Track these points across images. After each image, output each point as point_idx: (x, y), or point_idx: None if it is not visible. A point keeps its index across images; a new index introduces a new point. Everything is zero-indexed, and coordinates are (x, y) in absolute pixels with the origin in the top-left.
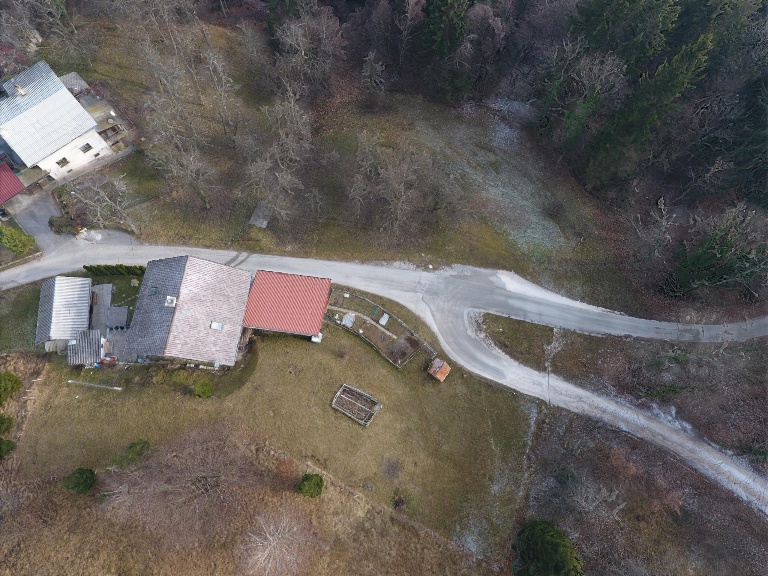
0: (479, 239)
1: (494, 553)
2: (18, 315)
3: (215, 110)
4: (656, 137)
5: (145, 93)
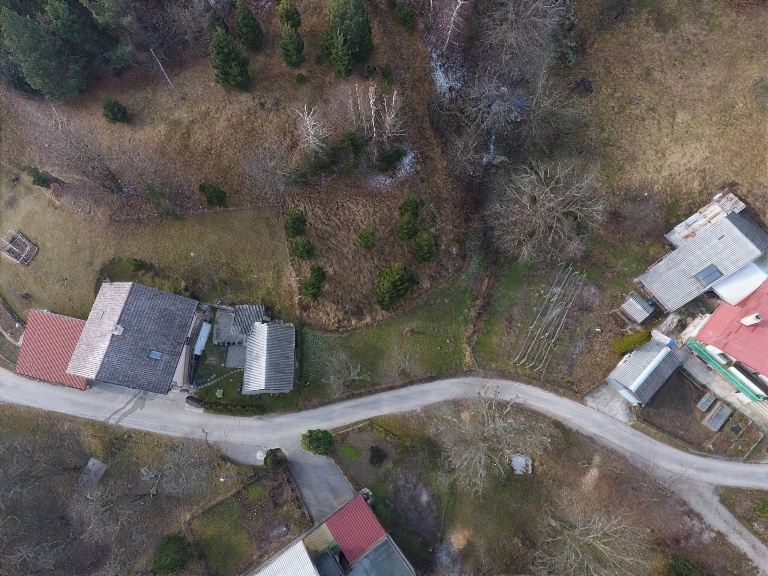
0: None
1: None
2: None
3: None
4: None
5: None
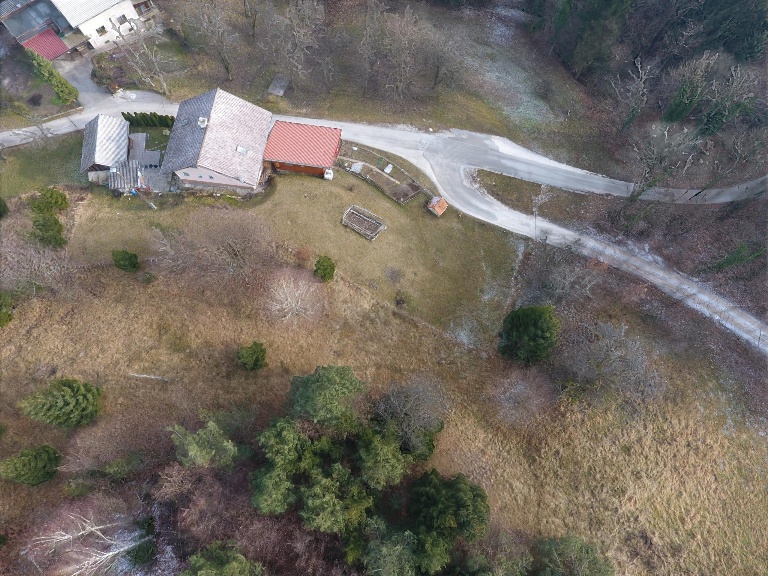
0: (475, 111)
1: (483, 345)
2: (63, 157)
3: (236, 3)
4: (635, 10)
5: None
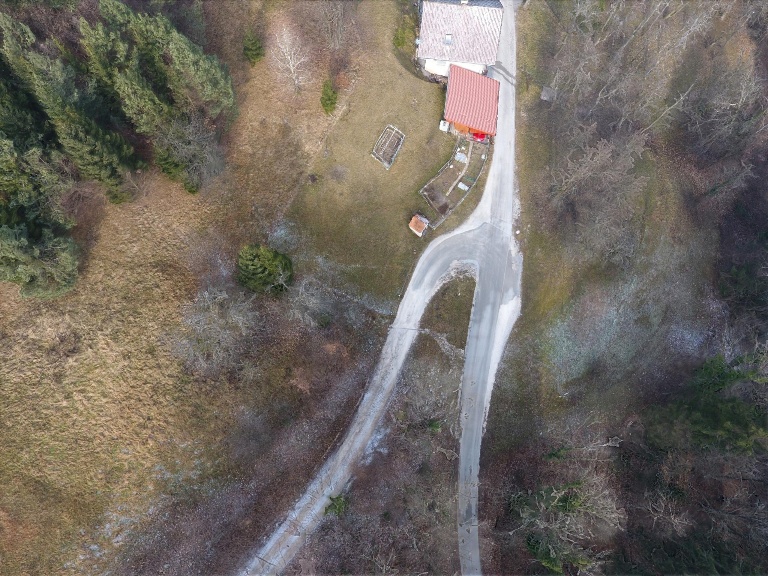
0: (553, 285)
1: None
2: None
3: None
4: None
5: (660, 6)
